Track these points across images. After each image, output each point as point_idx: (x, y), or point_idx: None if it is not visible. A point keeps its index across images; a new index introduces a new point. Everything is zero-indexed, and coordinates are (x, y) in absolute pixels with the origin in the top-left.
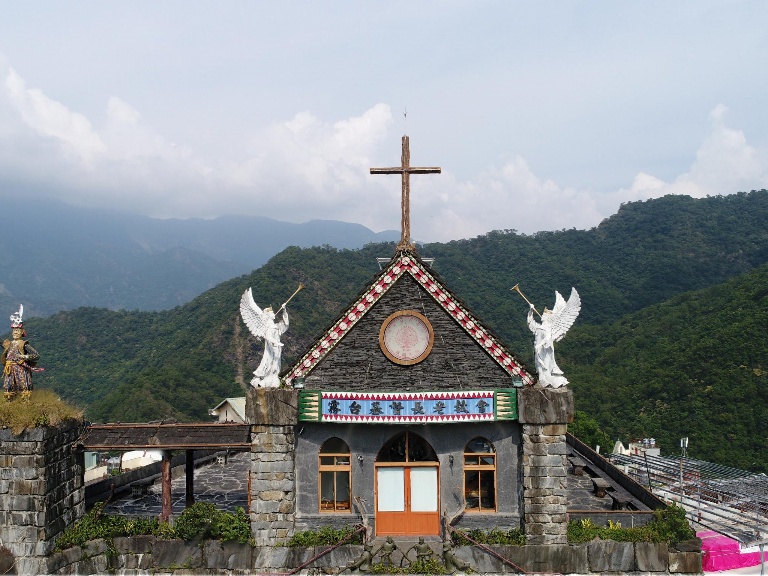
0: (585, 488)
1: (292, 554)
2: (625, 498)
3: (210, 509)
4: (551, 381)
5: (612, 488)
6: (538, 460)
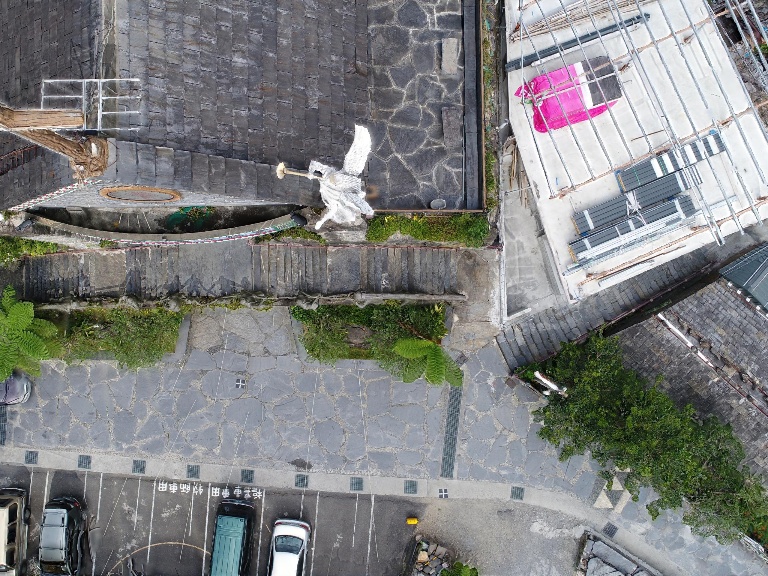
0: (438, 31)
1: (106, 245)
2: (454, 139)
3: (5, 243)
4: (342, 213)
5: (464, 57)
6: (332, 233)
